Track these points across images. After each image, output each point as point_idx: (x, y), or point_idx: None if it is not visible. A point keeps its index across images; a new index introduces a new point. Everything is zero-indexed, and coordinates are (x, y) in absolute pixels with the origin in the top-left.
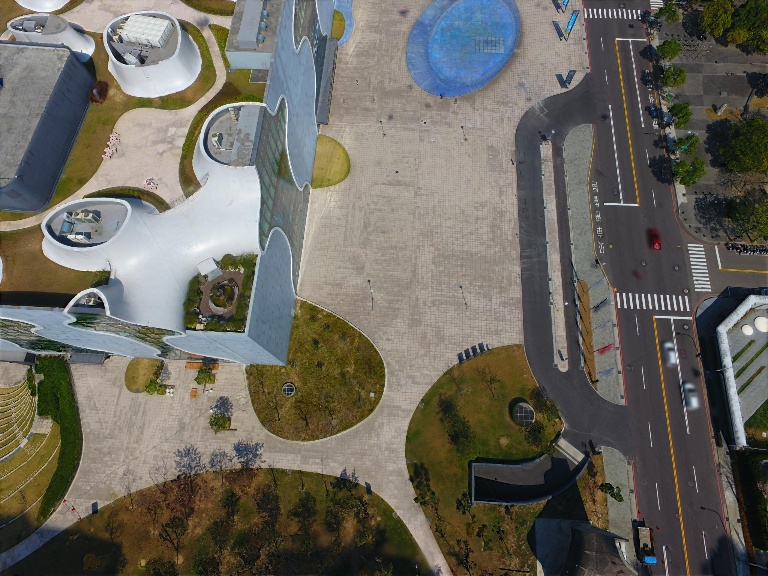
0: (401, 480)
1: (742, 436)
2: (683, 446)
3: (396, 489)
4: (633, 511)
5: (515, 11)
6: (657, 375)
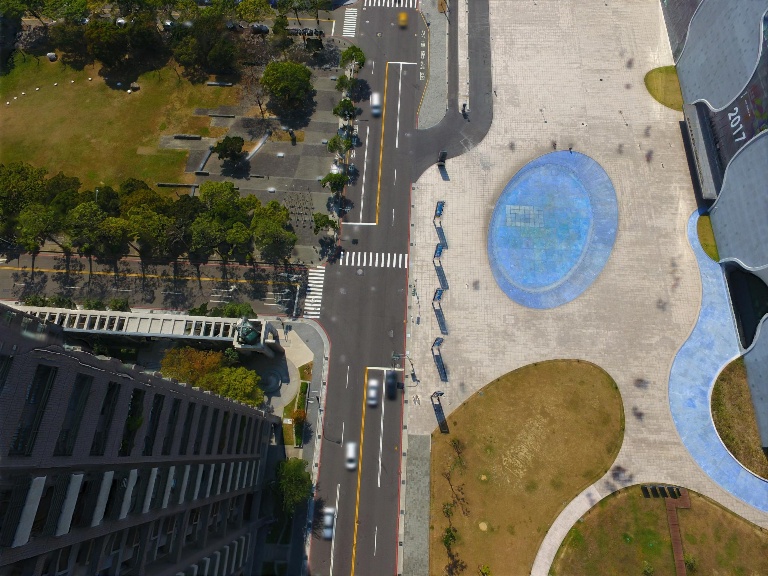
0: None
1: None
2: None
3: None
4: None
5: (493, 263)
6: None
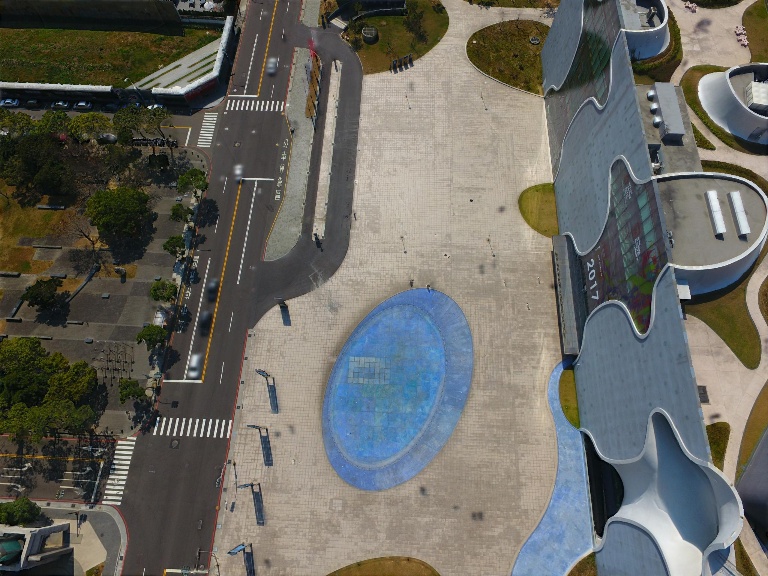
0: (450, 7)
1: (228, 20)
2: (263, 29)
3: (453, 3)
4: (305, 2)
5: (327, 431)
6: (268, 63)
